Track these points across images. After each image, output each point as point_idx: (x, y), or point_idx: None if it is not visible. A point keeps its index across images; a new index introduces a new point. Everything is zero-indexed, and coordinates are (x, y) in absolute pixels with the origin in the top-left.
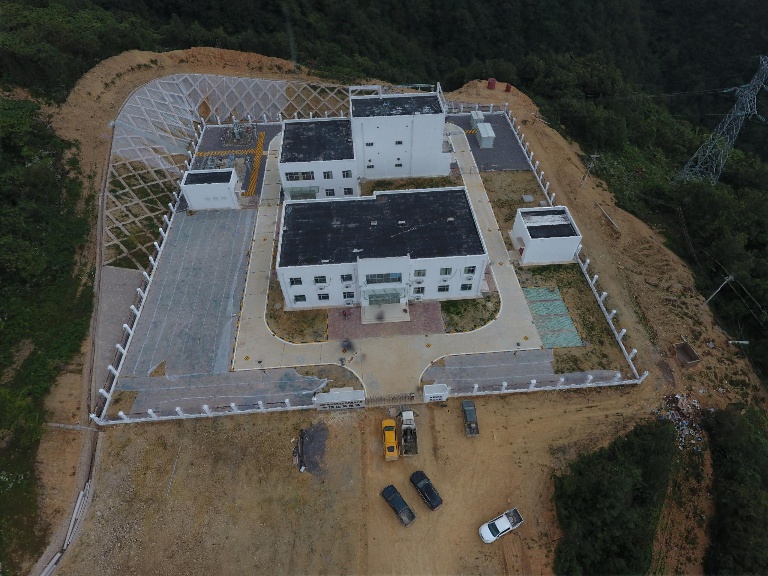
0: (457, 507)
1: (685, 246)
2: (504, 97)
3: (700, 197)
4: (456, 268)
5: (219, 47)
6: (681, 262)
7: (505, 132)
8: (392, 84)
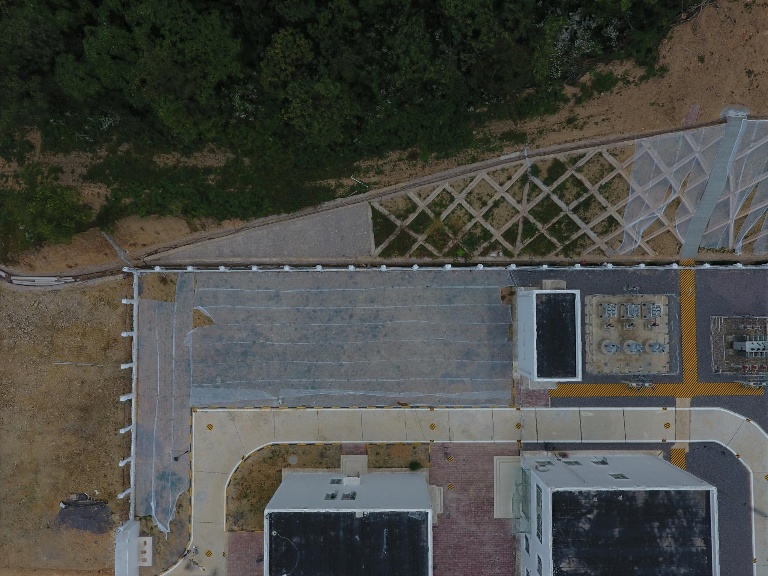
0: None
1: None
2: None
3: None
4: None
5: None
6: None
7: None
8: None
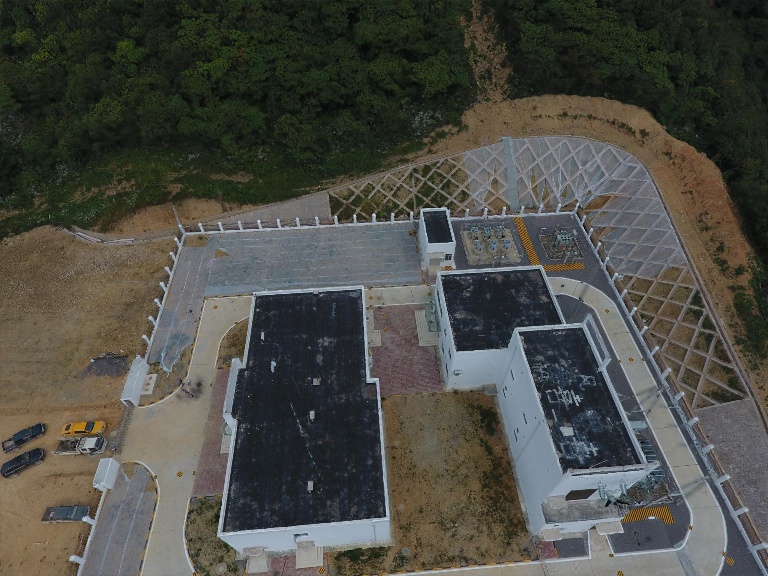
0: None
1: None
2: None
3: None
4: None
5: (725, 175)
6: None
7: None
8: None
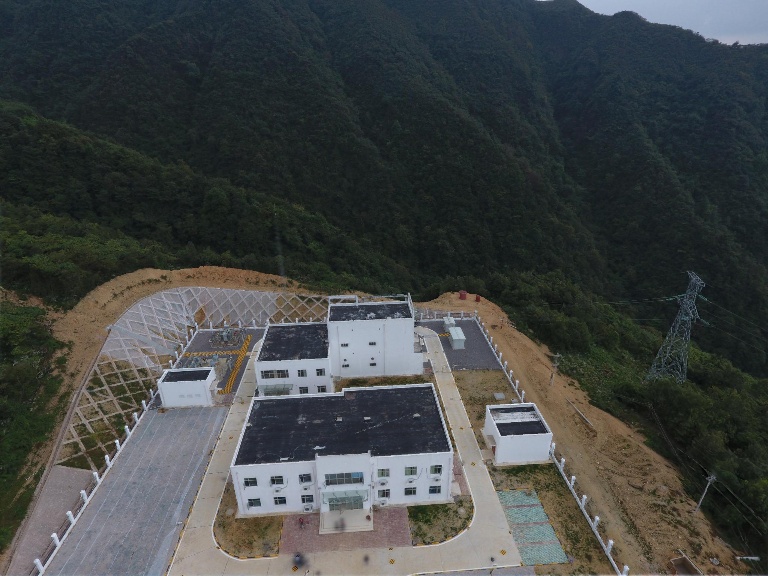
0: None
1: (667, 445)
2: (474, 306)
3: (669, 395)
4: (421, 467)
5: (224, 266)
6: (665, 462)
7: (476, 335)
8: (373, 295)
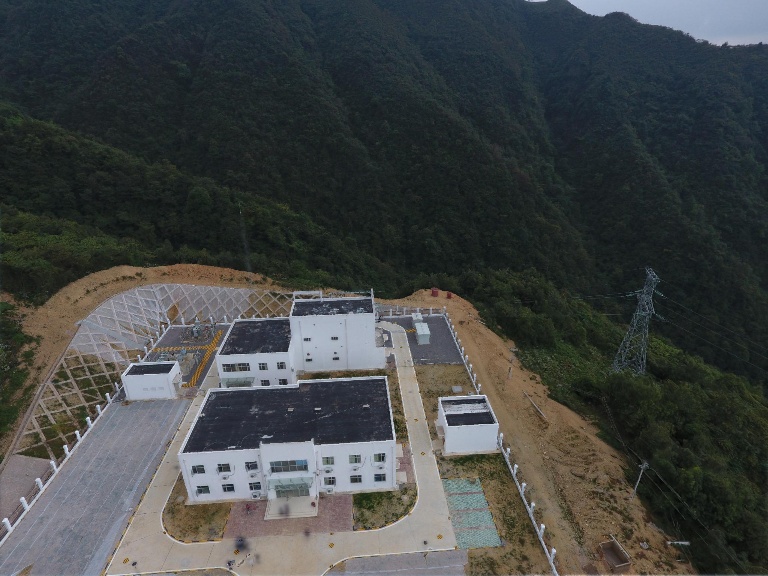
0: None
1: None
2: (445, 302)
3: (622, 388)
4: (365, 455)
5: (200, 264)
6: (612, 453)
7: (442, 331)
8: None
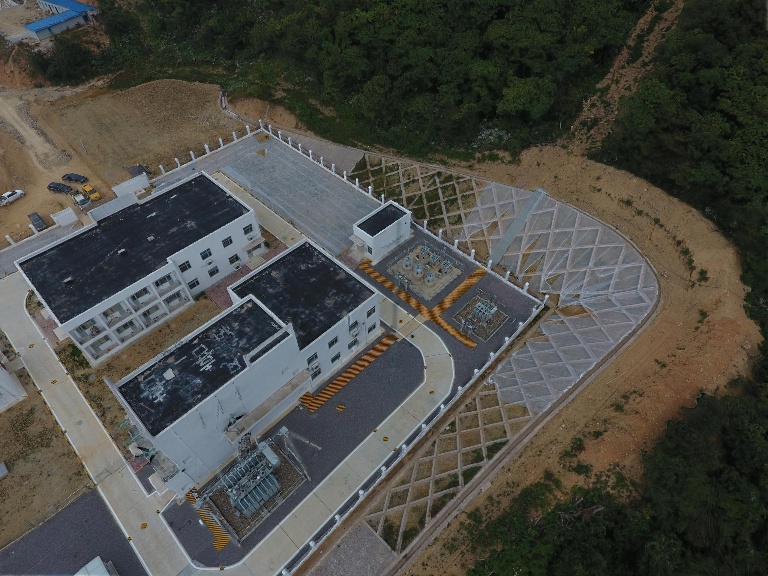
0: (40, 195)
1: None
2: None
3: None
4: None
5: None
6: None
7: None
8: None
